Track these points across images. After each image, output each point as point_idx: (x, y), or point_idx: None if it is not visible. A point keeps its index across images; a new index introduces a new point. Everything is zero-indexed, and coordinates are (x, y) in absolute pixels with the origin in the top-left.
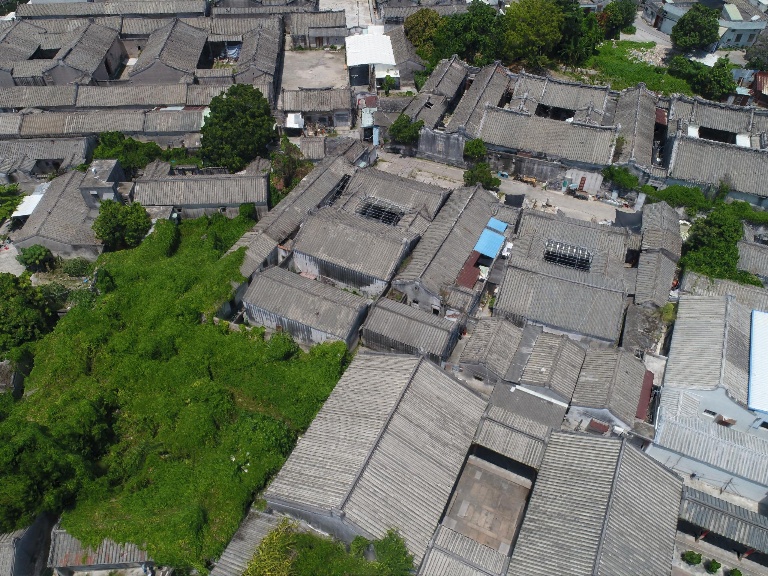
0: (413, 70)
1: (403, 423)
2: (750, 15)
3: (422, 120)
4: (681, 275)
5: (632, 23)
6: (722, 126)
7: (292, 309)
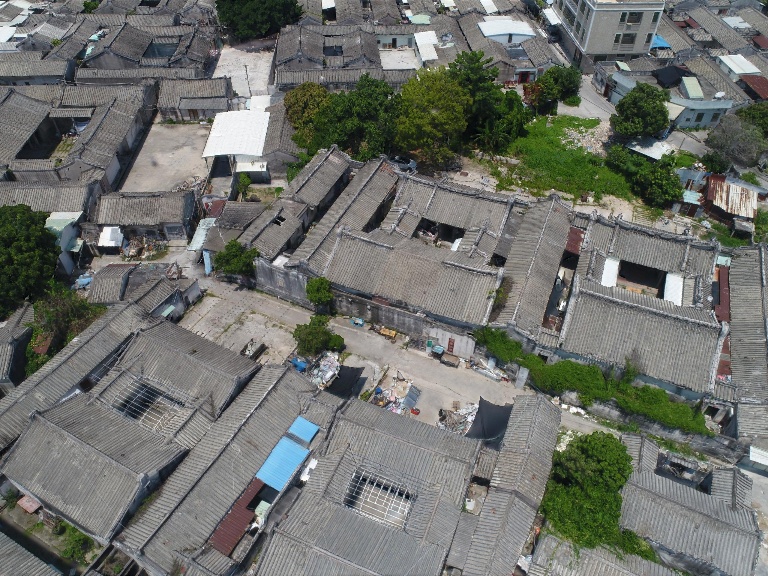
0: (284, 161)
1: None
2: (715, 89)
3: (255, 249)
4: (542, 527)
5: (576, 92)
6: (649, 261)
7: None
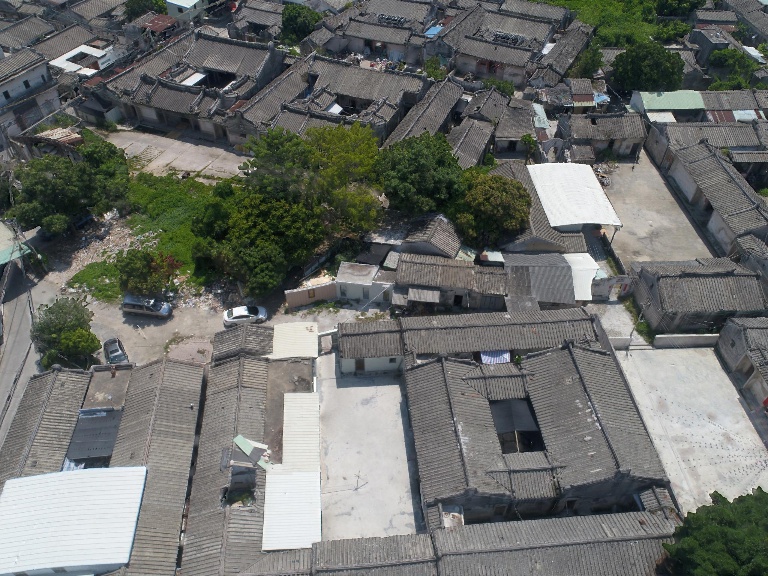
0: None
1: None
2: None
3: None
4: None
5: None
6: None
7: None
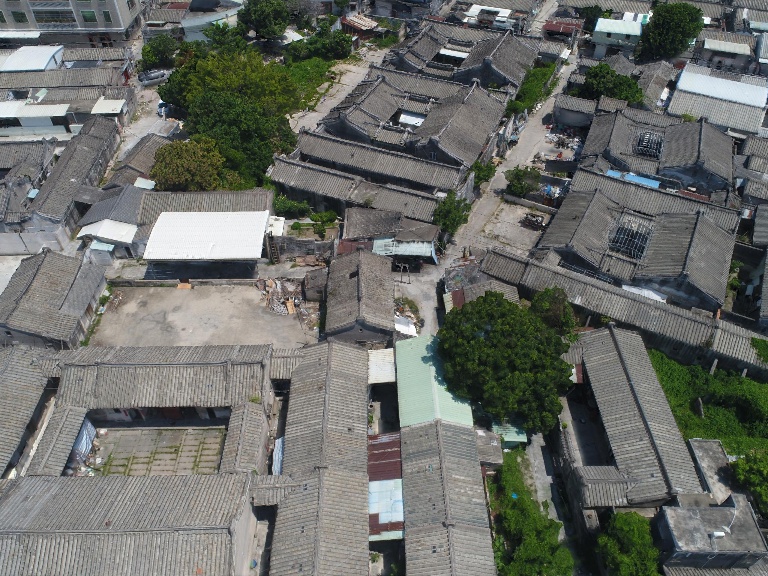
0: (272, 203)
1: None
2: None
3: None
4: None
5: None
6: (433, 52)
7: None
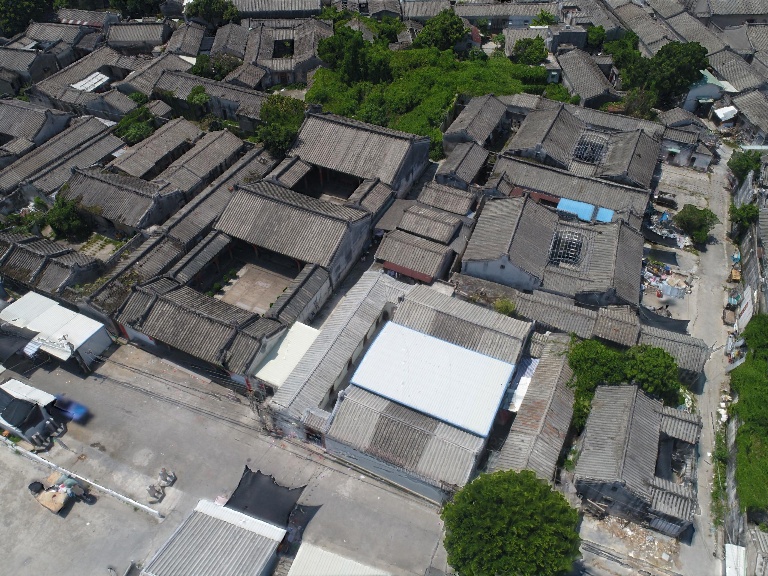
0: None
1: (364, 138)
2: None
3: (758, 164)
4: None
5: None
6: None
7: (465, 114)
